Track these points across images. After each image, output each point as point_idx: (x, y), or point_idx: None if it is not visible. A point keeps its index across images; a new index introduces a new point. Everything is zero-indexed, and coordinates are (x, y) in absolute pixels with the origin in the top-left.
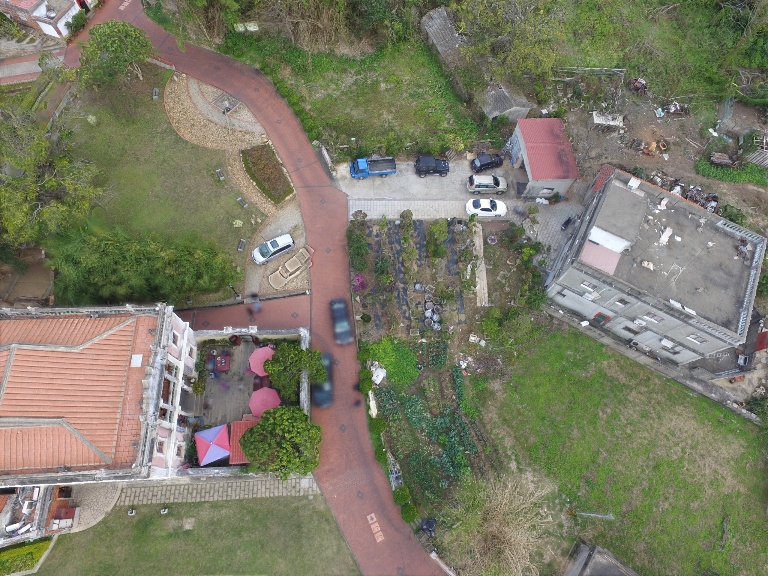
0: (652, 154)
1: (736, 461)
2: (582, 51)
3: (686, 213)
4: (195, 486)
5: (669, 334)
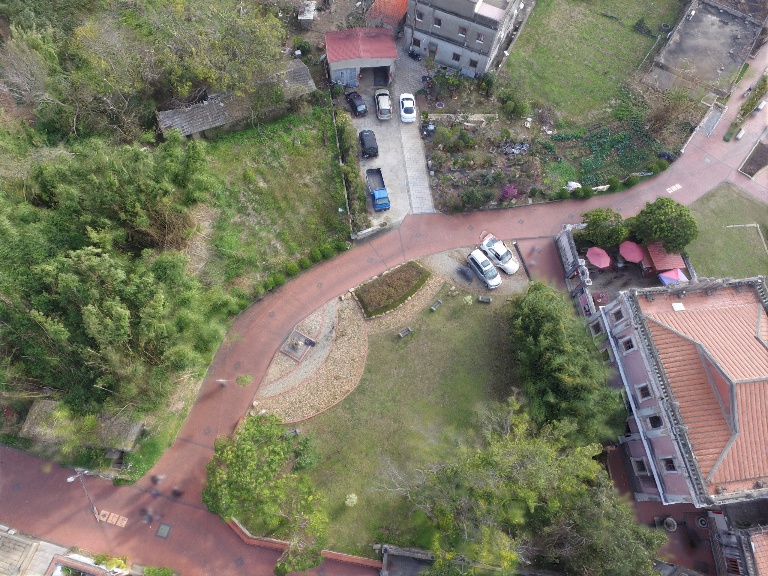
0: None
1: (570, 3)
2: None
3: None
4: None
5: None
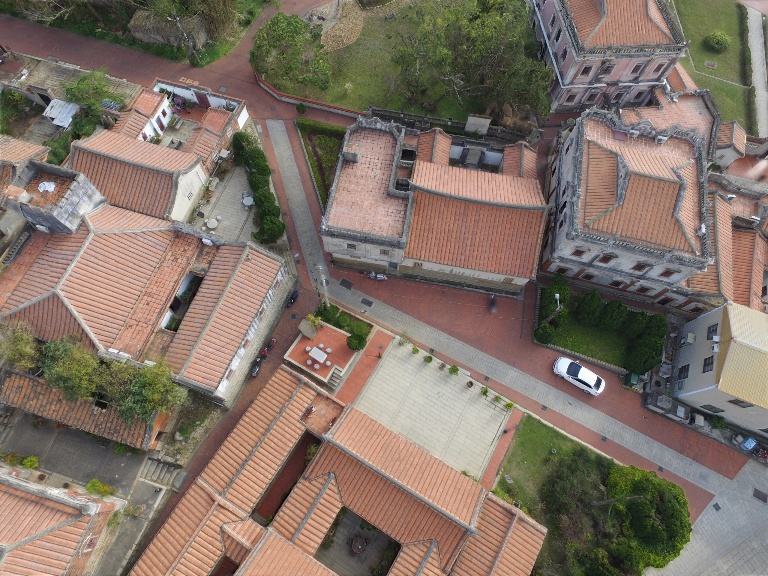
0: None
1: None
2: None
3: None
4: None
5: None
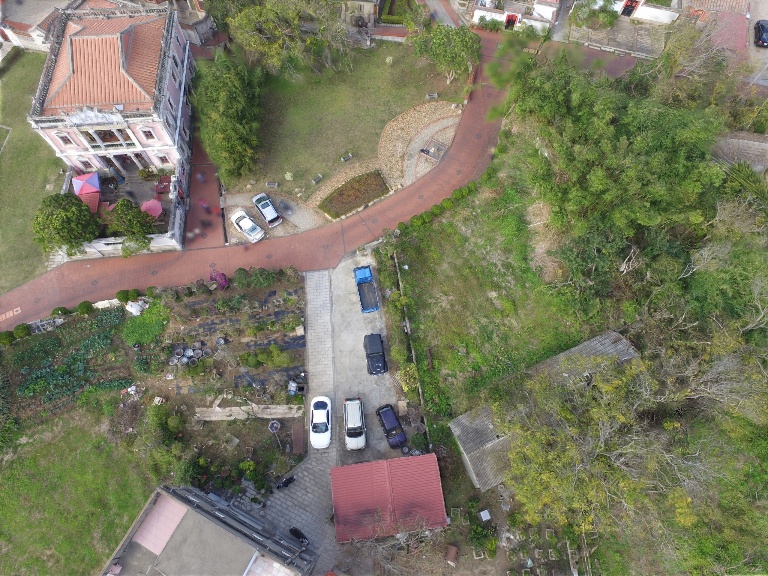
0: None
1: None
2: None
3: None
4: None
5: None
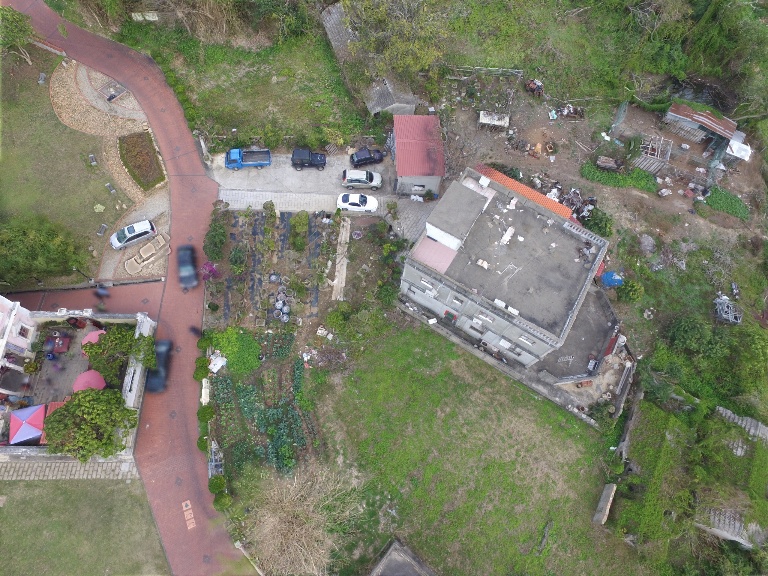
0: (537, 156)
1: (570, 466)
2: (484, 51)
3: (535, 214)
4: (14, 464)
5: (505, 334)
